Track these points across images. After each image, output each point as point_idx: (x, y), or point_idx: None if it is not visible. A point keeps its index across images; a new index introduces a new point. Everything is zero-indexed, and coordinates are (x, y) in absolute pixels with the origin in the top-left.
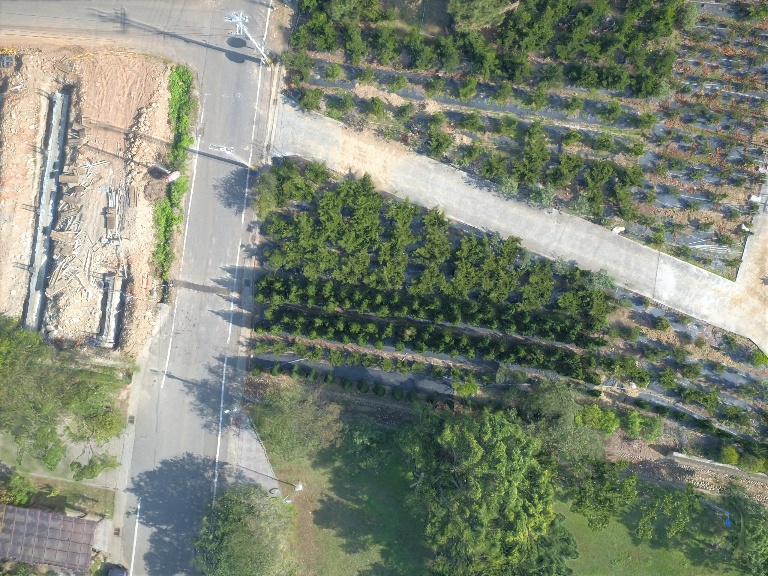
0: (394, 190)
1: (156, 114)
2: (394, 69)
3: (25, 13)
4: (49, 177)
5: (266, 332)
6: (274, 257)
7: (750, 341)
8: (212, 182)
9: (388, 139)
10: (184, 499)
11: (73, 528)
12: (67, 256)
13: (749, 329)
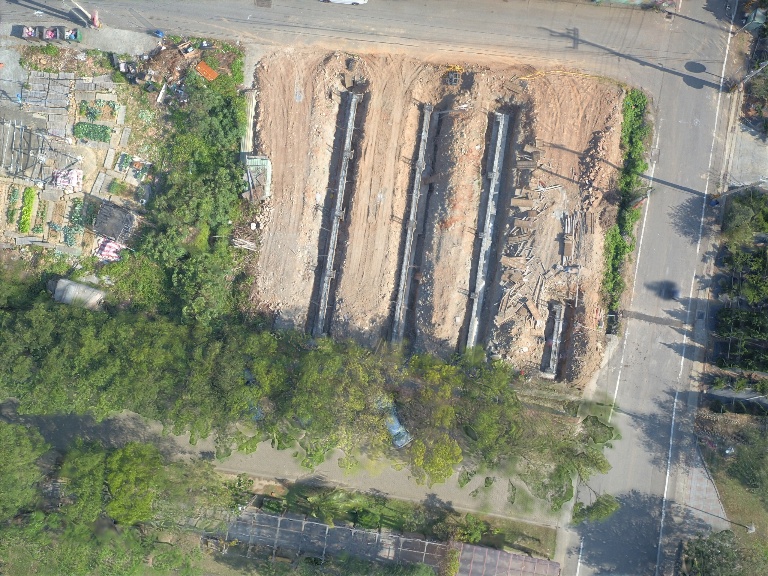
0: None
1: (612, 138)
2: None
3: (473, 29)
4: None
5: None
6: (744, 290)
7: None
8: (667, 210)
9: None
10: (629, 539)
11: (536, 569)
12: (516, 283)
13: None
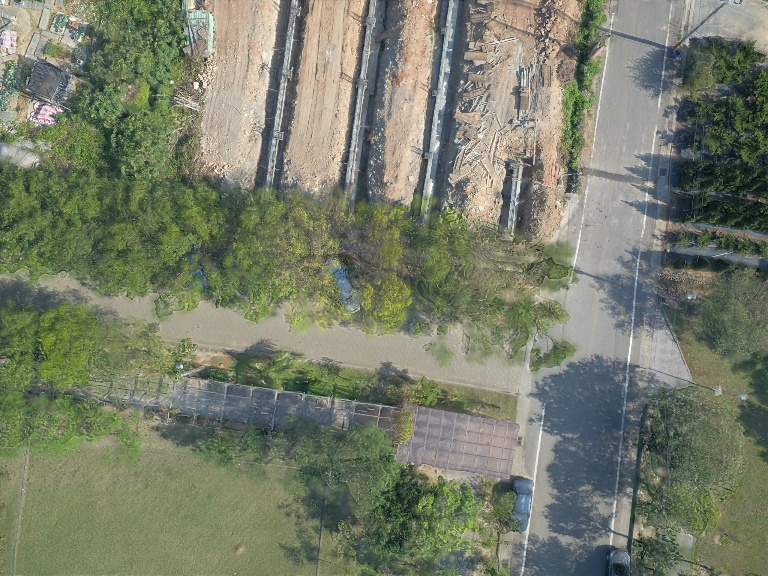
0: None
1: None
2: None
3: None
4: (445, 56)
5: (683, 225)
6: (707, 141)
7: None
8: (626, 63)
9: None
10: (592, 405)
11: (494, 431)
12: (471, 140)
13: None
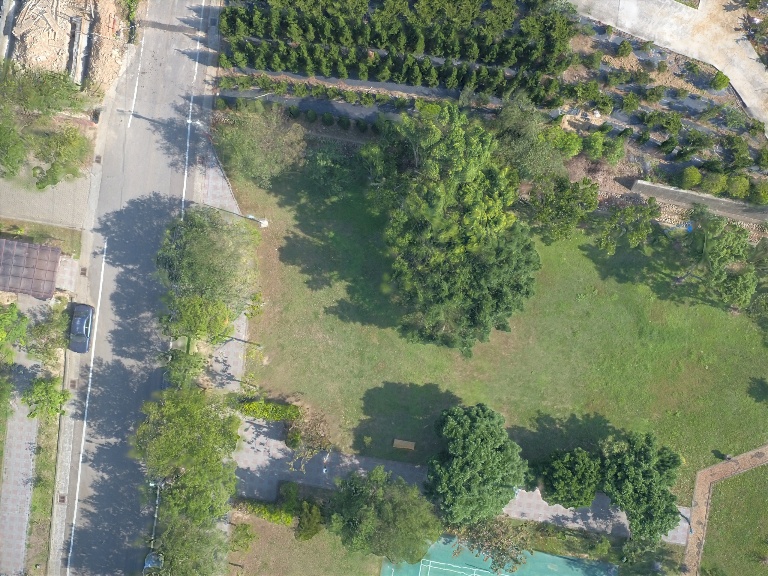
0: None
1: None
2: None
3: None
4: None
5: (232, 70)
6: None
7: (713, 68)
8: None
9: None
10: (150, 238)
11: (38, 255)
12: None
13: (712, 55)
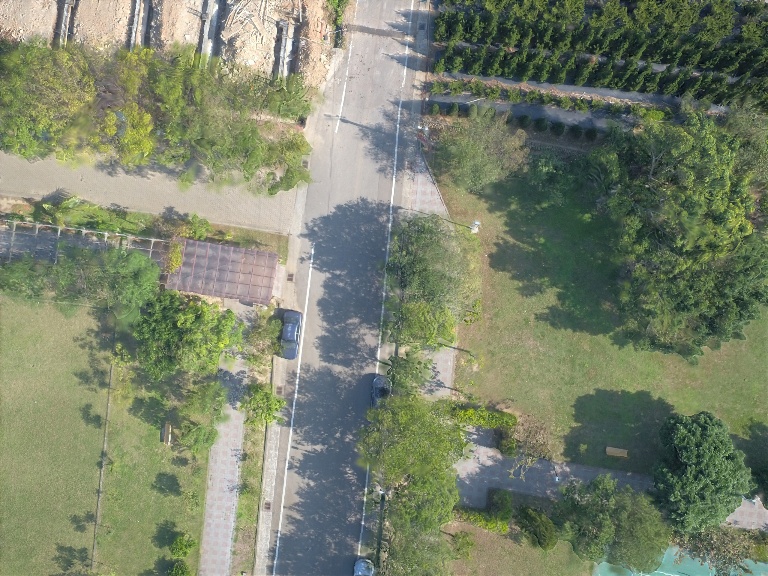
0: None
1: None
2: None
3: None
4: None
5: (441, 75)
6: None
7: None
8: None
9: None
10: (358, 244)
11: (255, 261)
12: None
13: None
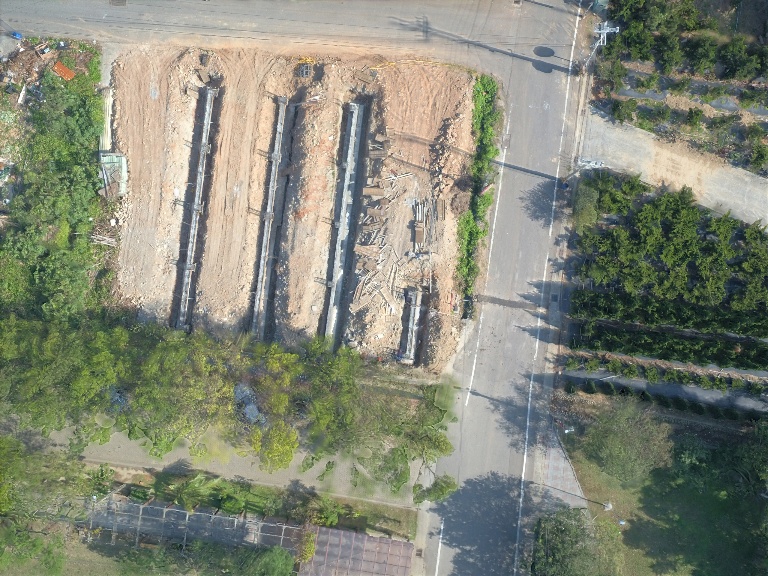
0: (709, 203)
1: (462, 125)
2: (706, 79)
3: (323, 21)
4: (347, 189)
5: None
6: (592, 272)
7: None
8: (518, 195)
9: (703, 151)
10: (488, 519)
11: (390, 550)
12: (371, 271)
13: None
